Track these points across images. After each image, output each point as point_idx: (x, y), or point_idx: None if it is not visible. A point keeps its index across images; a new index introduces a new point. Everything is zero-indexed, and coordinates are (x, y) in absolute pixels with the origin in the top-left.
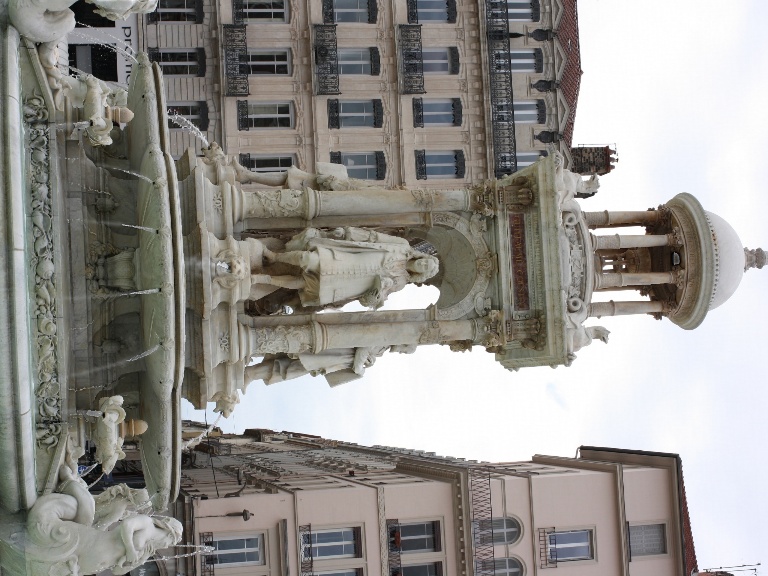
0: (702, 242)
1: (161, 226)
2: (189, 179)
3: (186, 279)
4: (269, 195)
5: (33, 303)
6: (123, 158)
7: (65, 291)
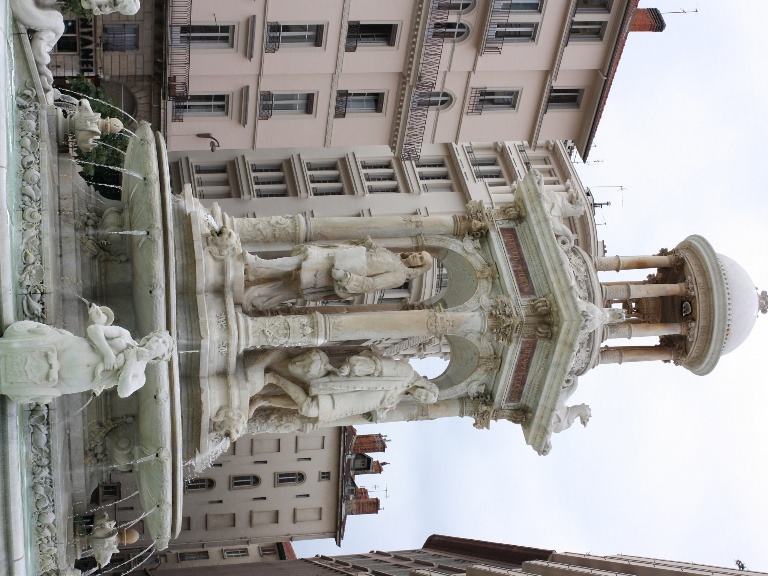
0: (712, 345)
1: (162, 503)
2: (194, 341)
3: (184, 429)
4: (277, 334)
5: (35, 537)
6: (125, 261)
7: (65, 502)
